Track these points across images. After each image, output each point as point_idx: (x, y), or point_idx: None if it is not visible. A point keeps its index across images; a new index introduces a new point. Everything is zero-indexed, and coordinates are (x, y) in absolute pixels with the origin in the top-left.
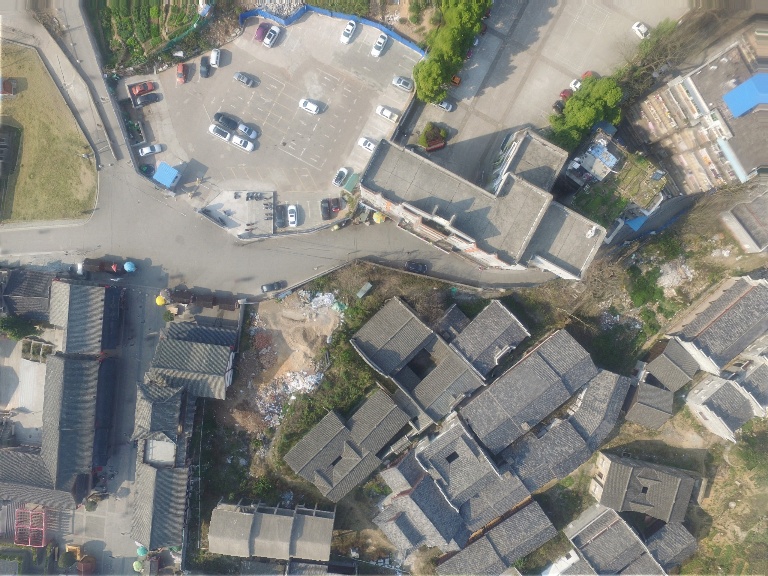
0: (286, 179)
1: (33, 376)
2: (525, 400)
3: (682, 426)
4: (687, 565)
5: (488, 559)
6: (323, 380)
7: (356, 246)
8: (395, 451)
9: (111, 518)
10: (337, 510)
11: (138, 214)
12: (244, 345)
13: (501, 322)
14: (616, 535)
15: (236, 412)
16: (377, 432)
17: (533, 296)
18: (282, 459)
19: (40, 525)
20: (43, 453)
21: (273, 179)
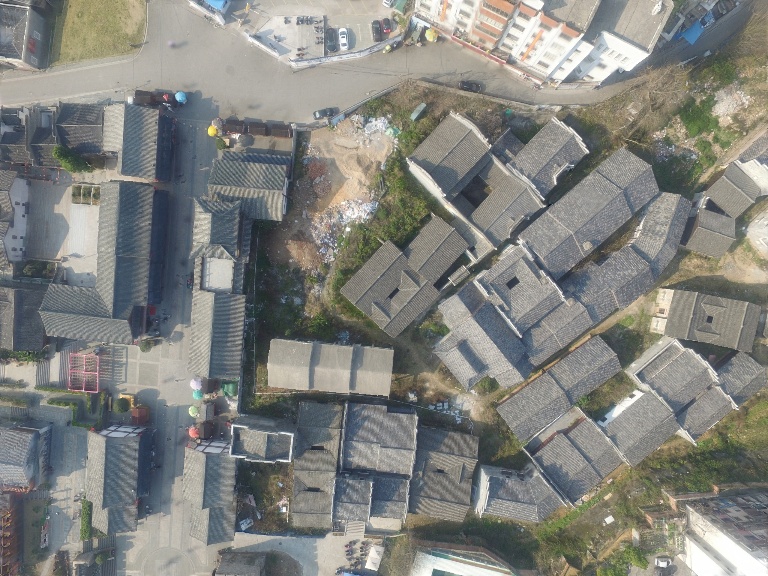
0: (336, 3)
1: (84, 219)
2: (587, 215)
3: (743, 260)
4: (754, 407)
5: (551, 394)
6: (378, 208)
7: (408, 69)
8: (453, 281)
9: (165, 364)
10: (394, 351)
11: (187, 46)
12: (298, 173)
13: (559, 139)
14: (683, 365)
15: (291, 243)
16: (435, 258)
17: (589, 117)
18: (337, 298)
19: (94, 370)
20: (98, 286)
21: (323, 3)
